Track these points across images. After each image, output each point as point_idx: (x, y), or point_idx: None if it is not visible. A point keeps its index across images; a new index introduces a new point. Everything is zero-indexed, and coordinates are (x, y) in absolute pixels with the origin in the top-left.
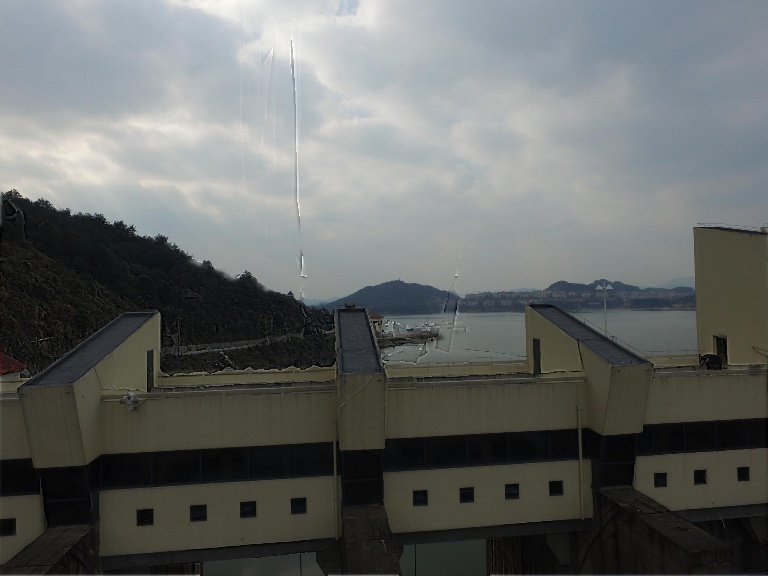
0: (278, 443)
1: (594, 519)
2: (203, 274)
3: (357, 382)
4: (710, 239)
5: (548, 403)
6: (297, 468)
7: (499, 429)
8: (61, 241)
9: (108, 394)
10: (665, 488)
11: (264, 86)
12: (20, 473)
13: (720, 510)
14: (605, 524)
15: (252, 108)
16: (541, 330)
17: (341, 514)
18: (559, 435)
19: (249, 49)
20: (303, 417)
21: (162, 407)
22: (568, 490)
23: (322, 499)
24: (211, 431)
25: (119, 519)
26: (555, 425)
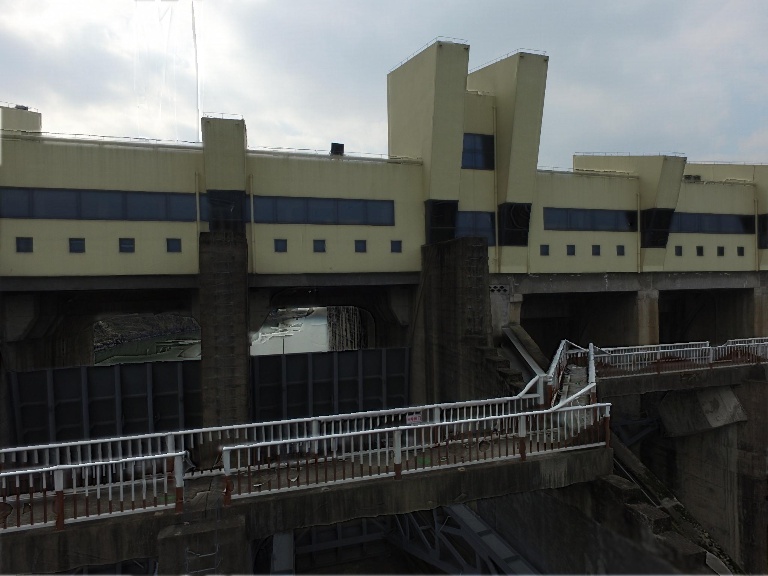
0: None
1: None
2: None
3: None
4: (392, 81)
5: (167, 168)
6: None
7: (114, 187)
8: None
9: None
10: (285, 253)
11: (162, 46)
12: None
13: (340, 277)
14: None
15: (149, 70)
16: None
17: None
18: (179, 198)
19: (145, 5)
20: None
21: None
22: (186, 248)
23: None
24: None
25: None
26: (174, 188)
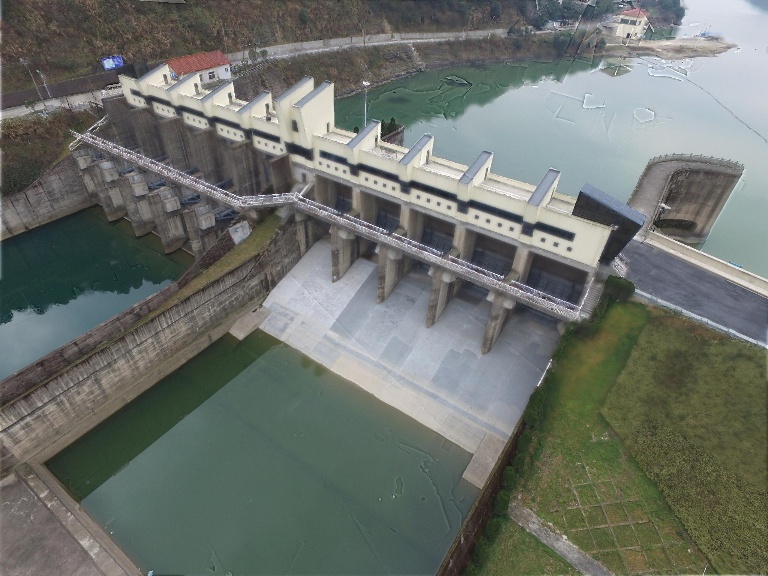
0: (201, 111)
1: None
2: None
3: None
4: None
5: None
6: None
7: None
8: None
9: (179, 94)
10: None
11: None
12: None
13: None
14: None
15: None
16: None
17: None
18: None
19: None
20: None
21: None
22: None
23: None
24: (192, 105)
25: (185, 117)
26: None
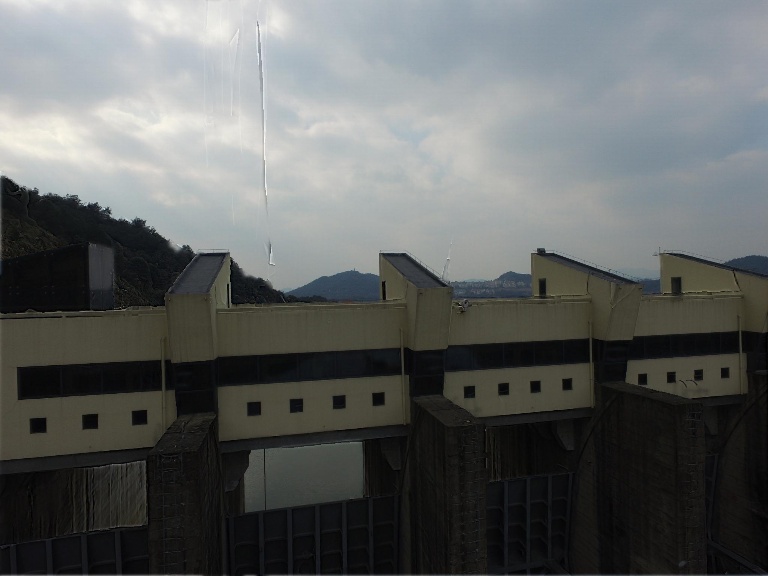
0: (553, 339)
1: (749, 394)
2: (186, 258)
3: (626, 290)
4: None
5: (720, 313)
6: (565, 357)
7: (690, 331)
8: (60, 220)
9: None
10: None
11: (230, 68)
12: (383, 360)
13: None
14: (763, 394)
15: (216, 90)
16: (684, 269)
17: (596, 390)
18: (726, 336)
19: (212, 29)
20: (569, 320)
21: (479, 312)
22: (732, 374)
23: (582, 380)
24: (510, 330)
25: (452, 393)
26: (724, 328)
